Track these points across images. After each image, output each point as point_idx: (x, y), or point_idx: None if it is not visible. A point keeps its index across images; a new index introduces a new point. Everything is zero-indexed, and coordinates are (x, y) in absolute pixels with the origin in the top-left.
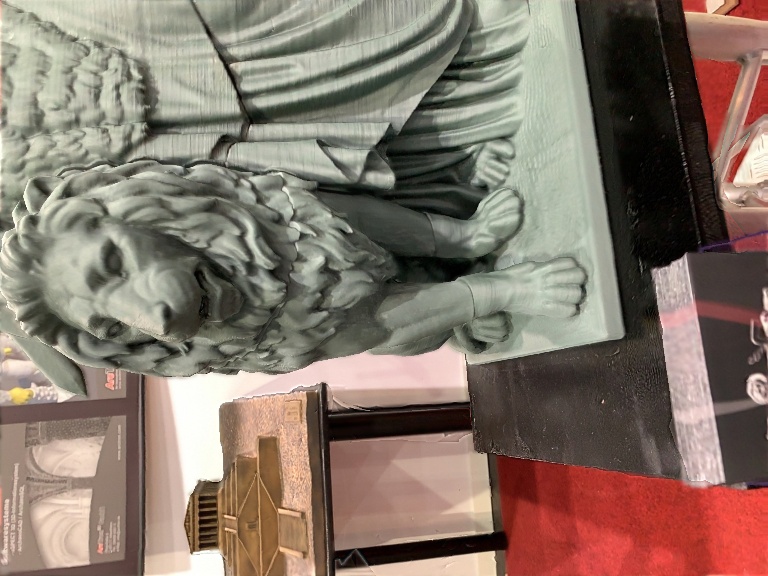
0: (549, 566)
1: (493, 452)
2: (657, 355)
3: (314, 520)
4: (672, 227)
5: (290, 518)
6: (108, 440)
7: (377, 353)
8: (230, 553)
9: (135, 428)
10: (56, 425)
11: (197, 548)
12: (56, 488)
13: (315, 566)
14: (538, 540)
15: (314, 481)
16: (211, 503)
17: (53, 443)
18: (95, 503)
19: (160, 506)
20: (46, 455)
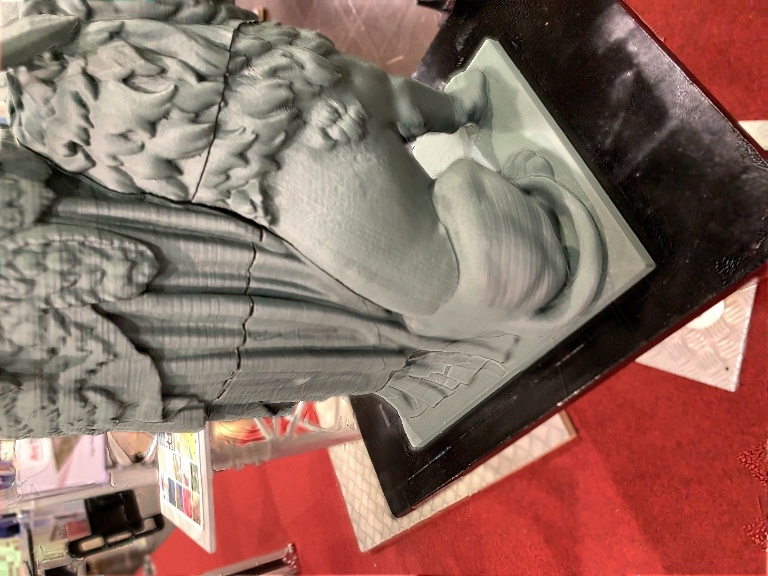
0: None
1: (767, 166)
2: (494, 8)
3: None
4: (438, 54)
5: None
6: None
7: (461, 172)
8: None
9: None
10: None
11: None
12: None
13: None
14: None
15: None
16: None
17: None
18: None
19: None
20: None
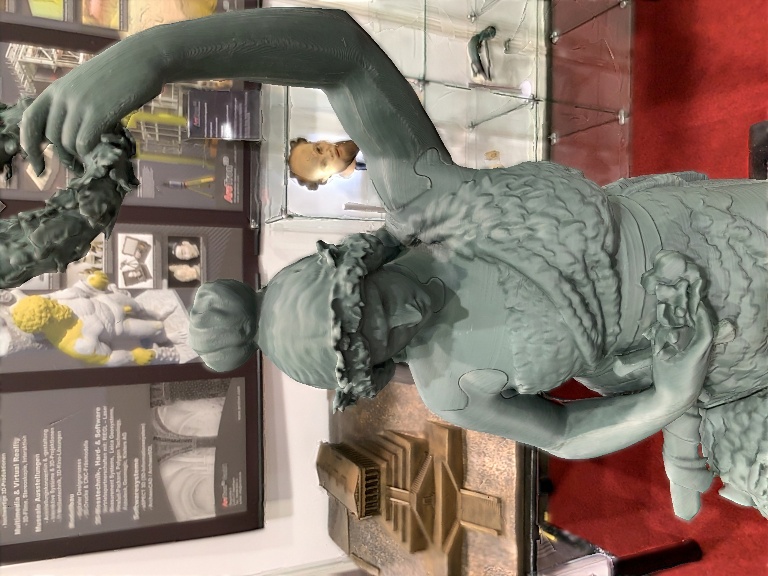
0: (606, 514)
1: None
2: None
3: (517, 507)
4: None
5: (478, 499)
6: (228, 401)
7: None
8: (396, 520)
9: (254, 390)
10: (179, 386)
11: (363, 514)
12: (182, 447)
13: (516, 544)
14: (596, 493)
15: (519, 475)
16: (374, 475)
17: (177, 404)
18: (218, 460)
19: (268, 459)
20: (171, 415)
